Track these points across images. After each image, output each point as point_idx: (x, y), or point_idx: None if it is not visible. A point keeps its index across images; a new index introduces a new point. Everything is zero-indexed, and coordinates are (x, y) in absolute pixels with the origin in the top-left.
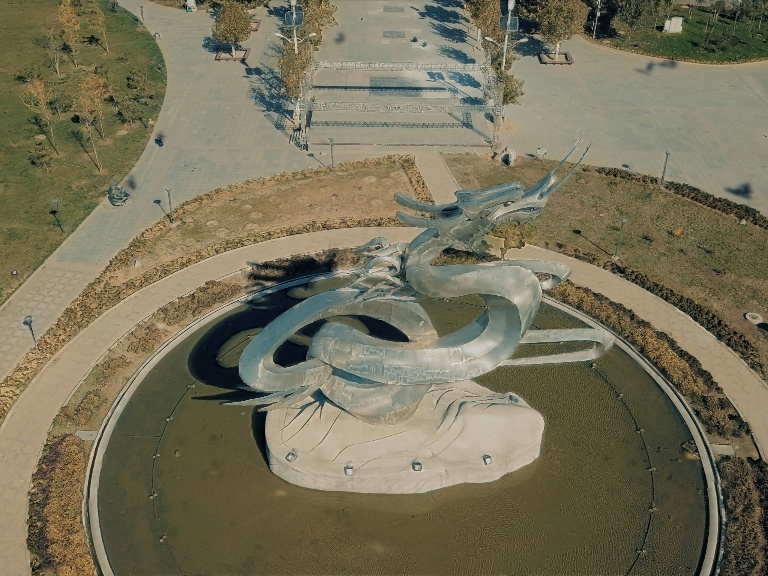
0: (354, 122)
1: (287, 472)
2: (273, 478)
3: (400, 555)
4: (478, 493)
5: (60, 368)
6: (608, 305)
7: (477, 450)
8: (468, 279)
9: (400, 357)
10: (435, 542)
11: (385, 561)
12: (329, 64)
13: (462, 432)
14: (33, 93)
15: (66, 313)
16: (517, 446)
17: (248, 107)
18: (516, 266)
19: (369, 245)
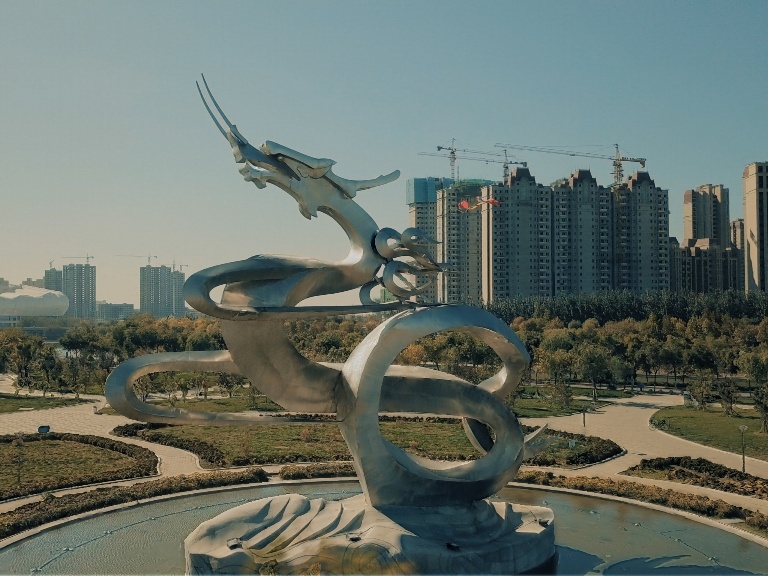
0: None
1: None
2: None
3: None
4: None
5: None
6: None
7: None
8: None
9: None
10: None
11: None
12: None
13: None
14: None
15: None
16: None
17: None
18: None
19: None
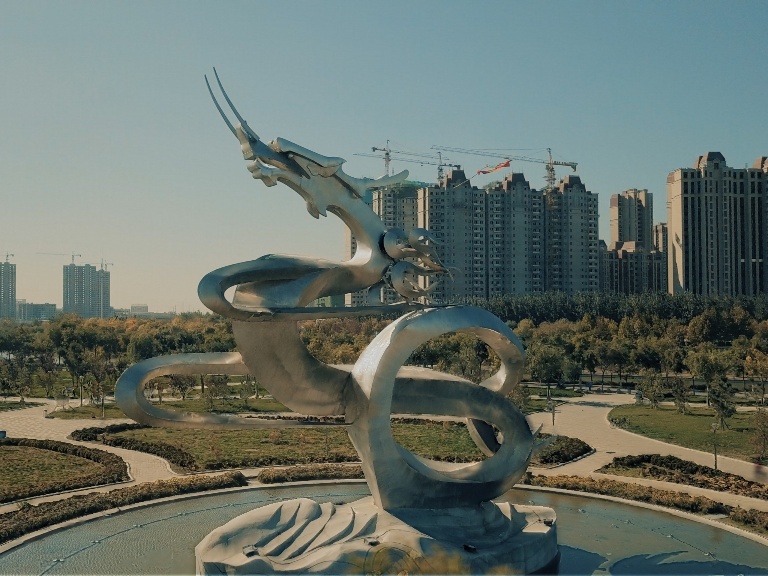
0: None
1: None
2: None
3: None
4: None
5: None
6: None
7: None
8: None
9: None
10: None
11: None
12: None
13: None
14: None
15: None
16: None
17: None
18: None
19: None
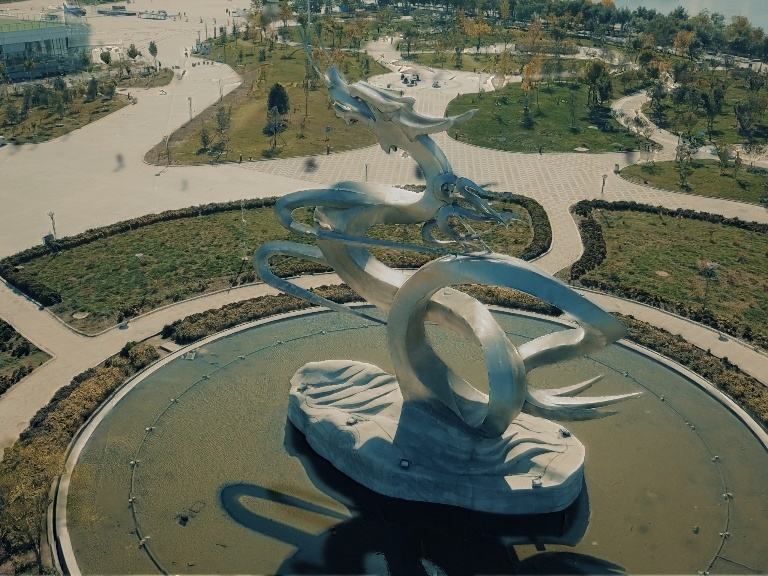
0: None
1: None
2: None
3: None
4: None
5: None
6: None
7: None
8: None
9: None
10: None
11: None
12: None
13: None
14: None
15: None
16: None
17: None
18: None
19: None
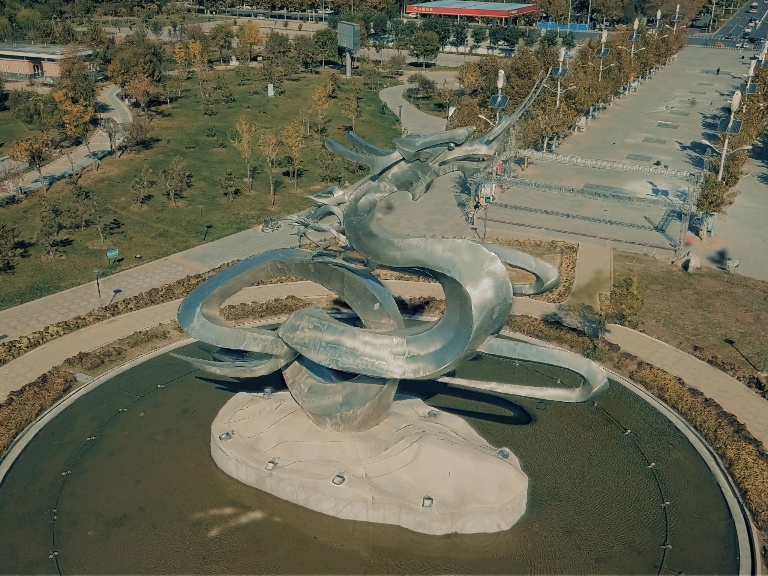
0: (535, 209)
1: (216, 452)
2: (208, 459)
3: (270, 567)
4: (415, 547)
5: (110, 327)
6: (713, 411)
7: (422, 488)
8: (413, 246)
9: (339, 335)
10: (318, 569)
11: (250, 567)
12: (530, 153)
13: (411, 462)
14: (239, 131)
15: (150, 290)
16: (473, 499)
17: (444, 187)
18: (475, 243)
19: (321, 192)
